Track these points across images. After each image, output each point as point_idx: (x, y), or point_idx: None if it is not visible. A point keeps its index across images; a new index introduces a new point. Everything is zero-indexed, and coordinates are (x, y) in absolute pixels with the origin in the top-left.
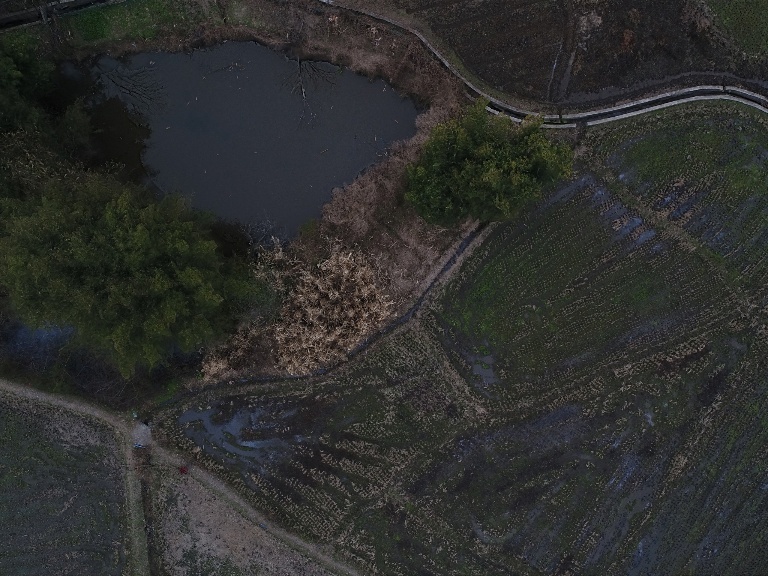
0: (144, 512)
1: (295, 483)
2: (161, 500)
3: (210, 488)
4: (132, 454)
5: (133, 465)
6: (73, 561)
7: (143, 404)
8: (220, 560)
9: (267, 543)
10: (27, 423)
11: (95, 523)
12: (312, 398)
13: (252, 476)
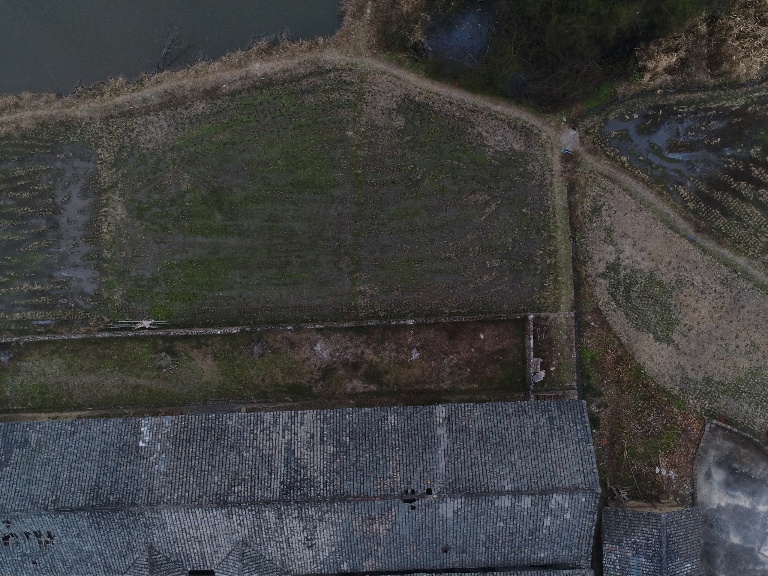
0: (570, 219)
1: (724, 196)
2: (586, 209)
3: (638, 197)
4: (559, 160)
5: (559, 171)
6: (492, 270)
7: (573, 107)
8: (644, 273)
9: (694, 257)
10: (450, 126)
11: (517, 231)
12: (743, 110)
13: (680, 188)
